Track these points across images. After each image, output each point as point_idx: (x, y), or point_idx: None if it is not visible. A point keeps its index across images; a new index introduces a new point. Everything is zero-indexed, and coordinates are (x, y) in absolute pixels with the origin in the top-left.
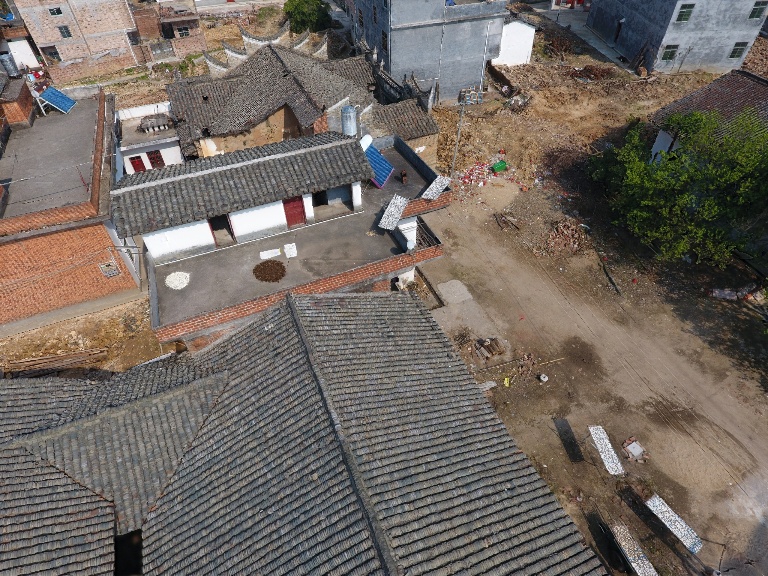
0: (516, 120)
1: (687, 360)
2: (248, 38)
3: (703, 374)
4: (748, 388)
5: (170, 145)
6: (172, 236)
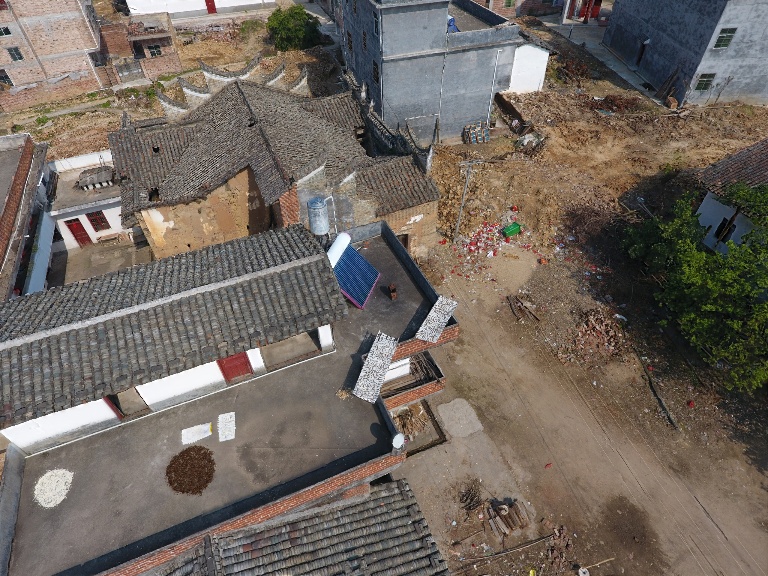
0: (530, 165)
1: None
2: (210, 74)
3: None
4: None
5: (115, 205)
6: (46, 420)
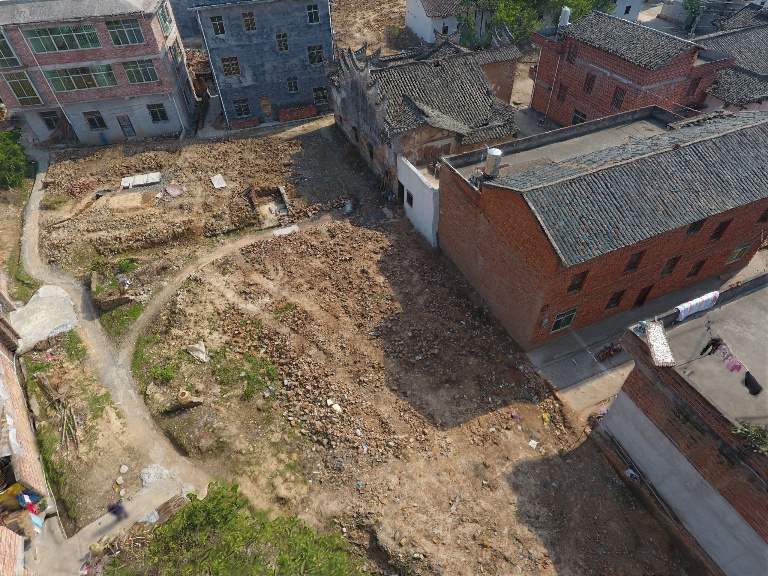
0: None
1: None
2: None
3: None
4: None
5: None
6: None
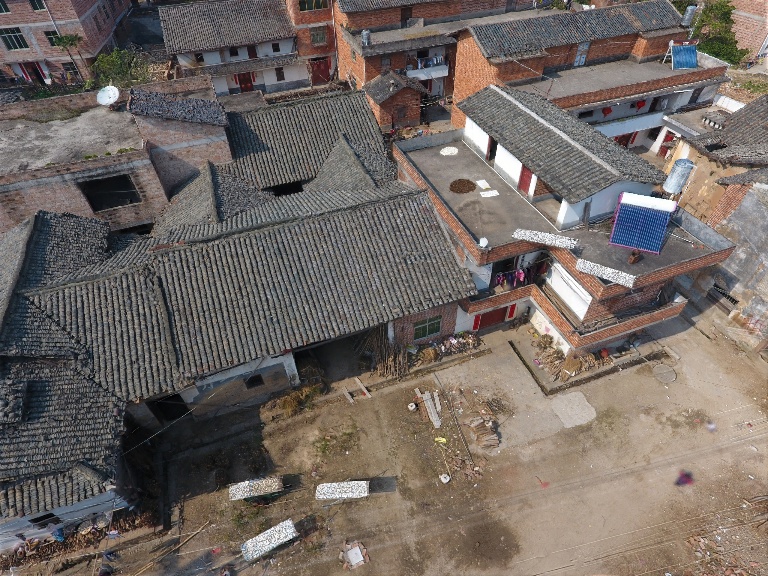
0: None
1: None
2: None
3: None
4: None
5: None
6: (475, 129)
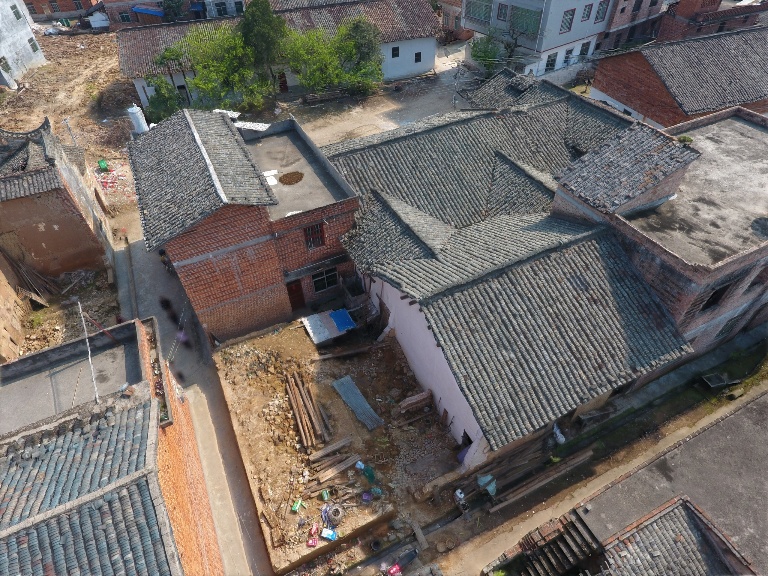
0: None
1: (318, 129)
2: None
3: (327, 127)
4: (336, 118)
5: None
6: None
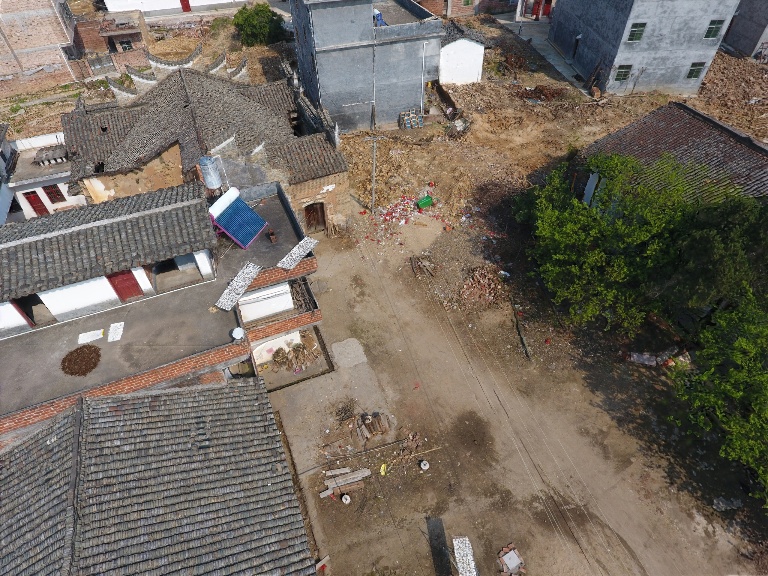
0: (453, 147)
1: (590, 442)
2: (156, 63)
3: (605, 460)
4: (652, 479)
5: (68, 179)
6: None
